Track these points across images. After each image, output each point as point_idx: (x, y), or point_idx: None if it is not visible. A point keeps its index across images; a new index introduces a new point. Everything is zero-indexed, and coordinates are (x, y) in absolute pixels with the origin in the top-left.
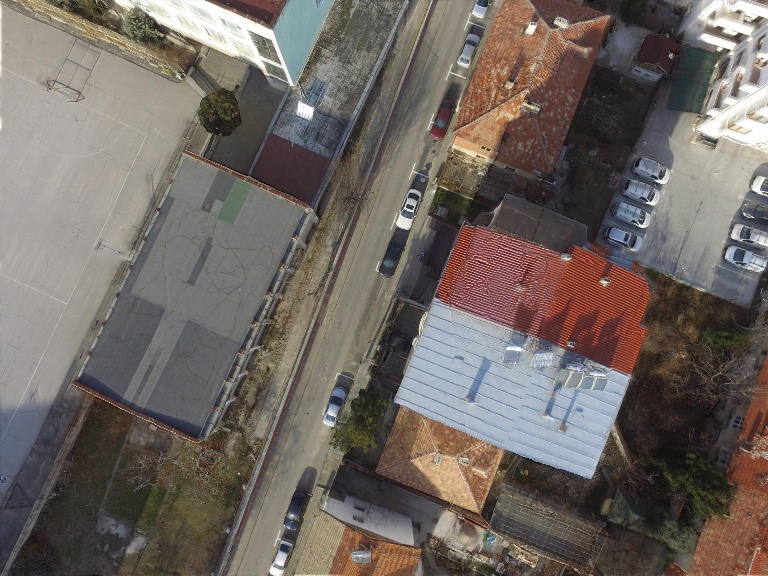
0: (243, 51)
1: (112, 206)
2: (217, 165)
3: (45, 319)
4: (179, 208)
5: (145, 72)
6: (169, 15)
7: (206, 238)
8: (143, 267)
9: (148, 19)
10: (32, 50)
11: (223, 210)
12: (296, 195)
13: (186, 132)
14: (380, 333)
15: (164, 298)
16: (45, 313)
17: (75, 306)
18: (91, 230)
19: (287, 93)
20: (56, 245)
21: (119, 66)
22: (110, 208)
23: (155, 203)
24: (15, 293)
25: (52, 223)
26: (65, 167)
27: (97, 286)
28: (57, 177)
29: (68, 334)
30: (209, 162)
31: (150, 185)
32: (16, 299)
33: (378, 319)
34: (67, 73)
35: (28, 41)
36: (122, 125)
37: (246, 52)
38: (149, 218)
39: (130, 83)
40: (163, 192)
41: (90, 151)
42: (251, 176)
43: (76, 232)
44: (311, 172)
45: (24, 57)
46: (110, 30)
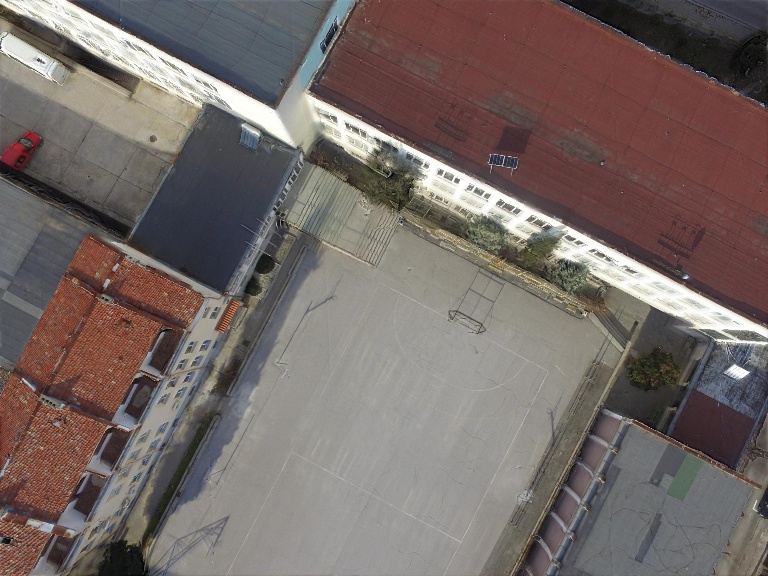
0: (689, 316)
1: (510, 443)
2: (669, 439)
3: (438, 556)
4: (626, 479)
5: (548, 306)
6: (625, 280)
7: (654, 513)
8: (587, 539)
9: (587, 273)
10: (434, 278)
11: (672, 485)
12: (721, 456)
13: (588, 371)
14: (756, 575)
15: (609, 573)
16: (439, 550)
17: (469, 545)
18: (488, 467)
19: (710, 347)
20: (452, 481)
21: (522, 299)
22: (508, 445)
23: (554, 443)
24: (409, 528)
25: (449, 458)
26: (463, 400)
27: (492, 525)
28: (455, 410)
29: (461, 573)
30: (661, 435)
31: (549, 423)
32: (410, 534)
33: (753, 560)
34: (469, 303)
35: (431, 268)
36: (522, 359)
37: (692, 317)
38: (547, 458)
39: (532, 317)
40: (563, 432)
41: (489, 385)
42: (673, 433)
43: (473, 468)
44: (736, 433)
45: (426, 284)
46: (537, 275)
